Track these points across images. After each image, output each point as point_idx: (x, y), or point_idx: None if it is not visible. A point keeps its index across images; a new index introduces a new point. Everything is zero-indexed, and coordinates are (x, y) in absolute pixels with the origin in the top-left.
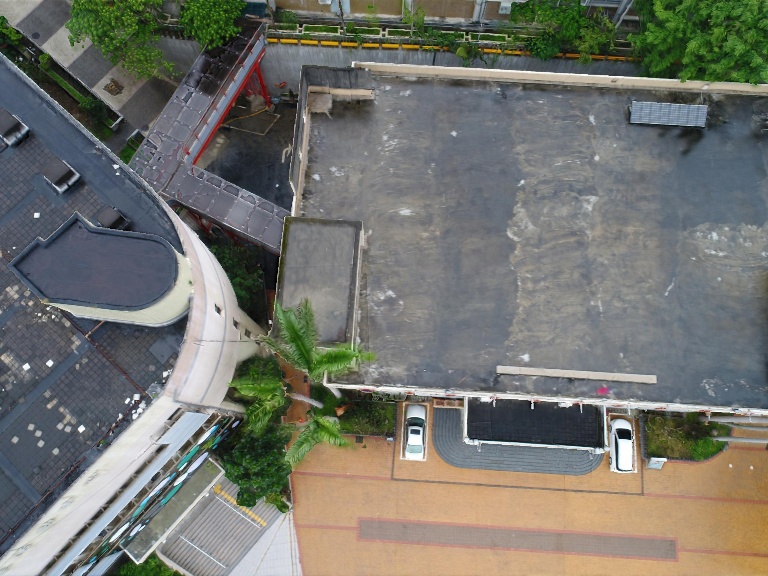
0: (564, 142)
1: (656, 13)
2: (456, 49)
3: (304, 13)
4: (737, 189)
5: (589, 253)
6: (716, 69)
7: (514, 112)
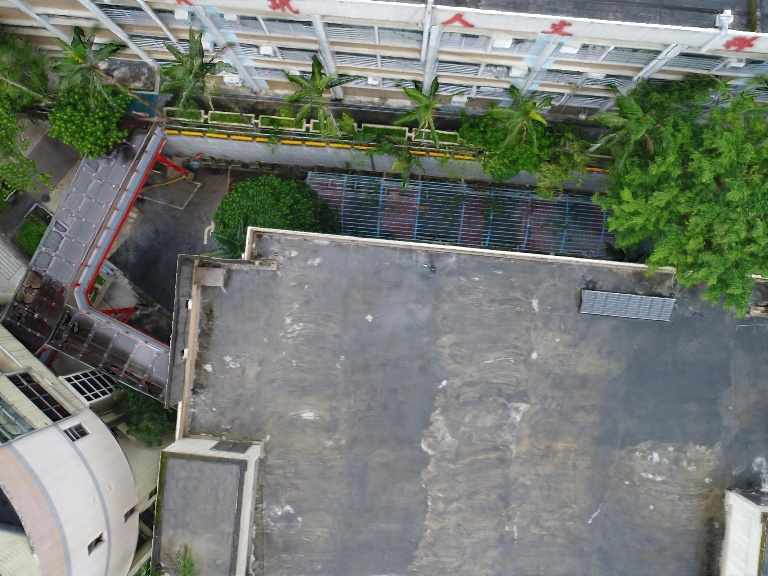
0: (498, 334)
1: (622, 206)
2: (395, 153)
3: (212, 87)
4: (692, 401)
5: (510, 472)
6: (685, 285)
7: (443, 292)
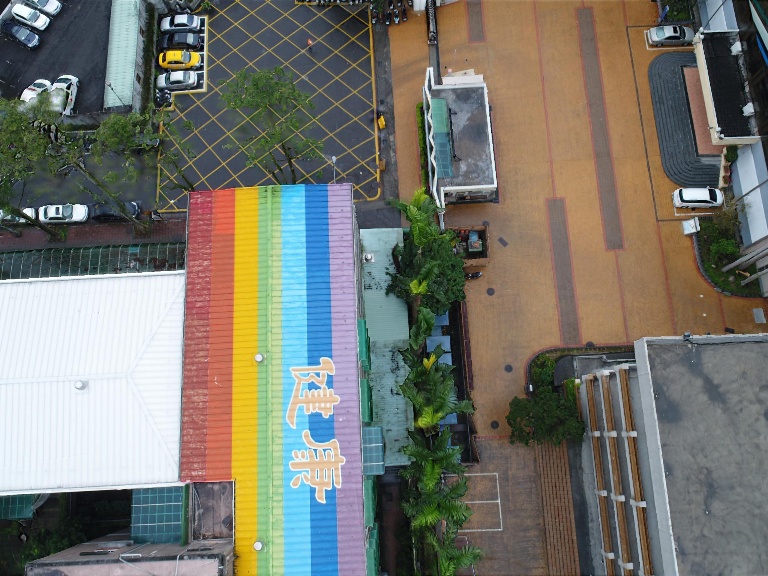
0: None
1: None
2: None
3: None
4: None
5: None
6: None
7: None
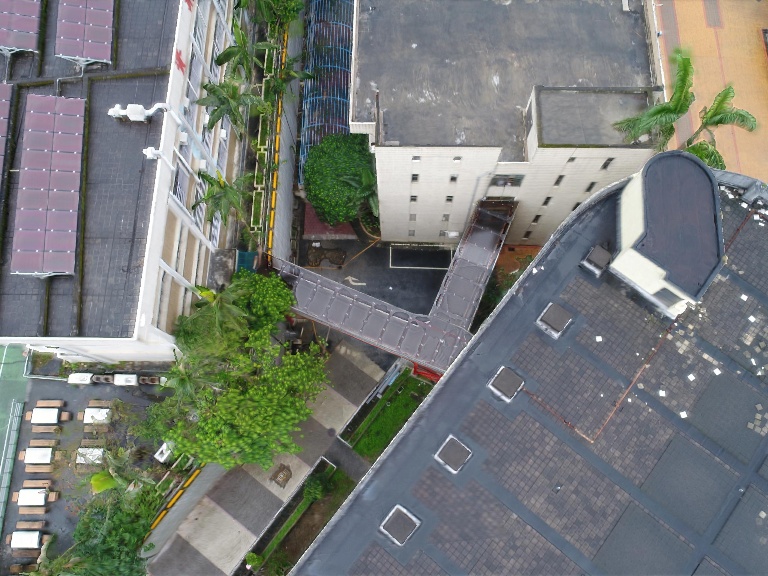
0: None
1: None
2: None
3: (230, 234)
4: None
5: None
6: None
7: (389, 1)
